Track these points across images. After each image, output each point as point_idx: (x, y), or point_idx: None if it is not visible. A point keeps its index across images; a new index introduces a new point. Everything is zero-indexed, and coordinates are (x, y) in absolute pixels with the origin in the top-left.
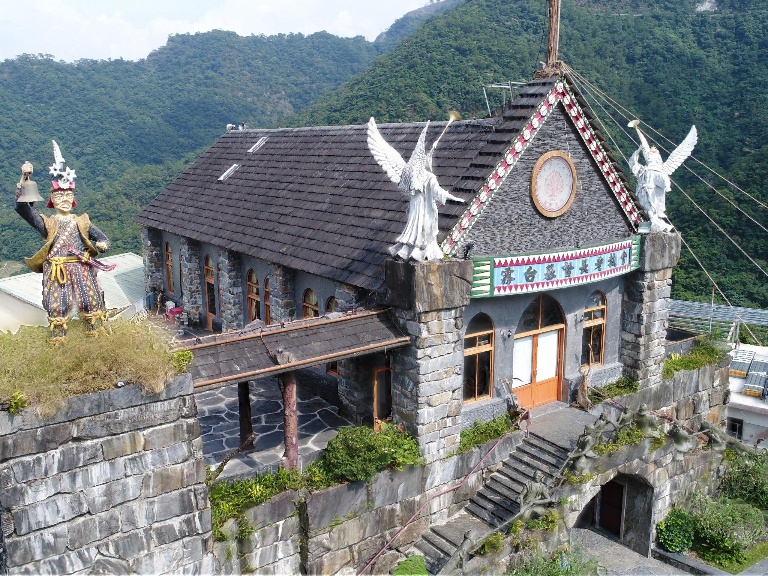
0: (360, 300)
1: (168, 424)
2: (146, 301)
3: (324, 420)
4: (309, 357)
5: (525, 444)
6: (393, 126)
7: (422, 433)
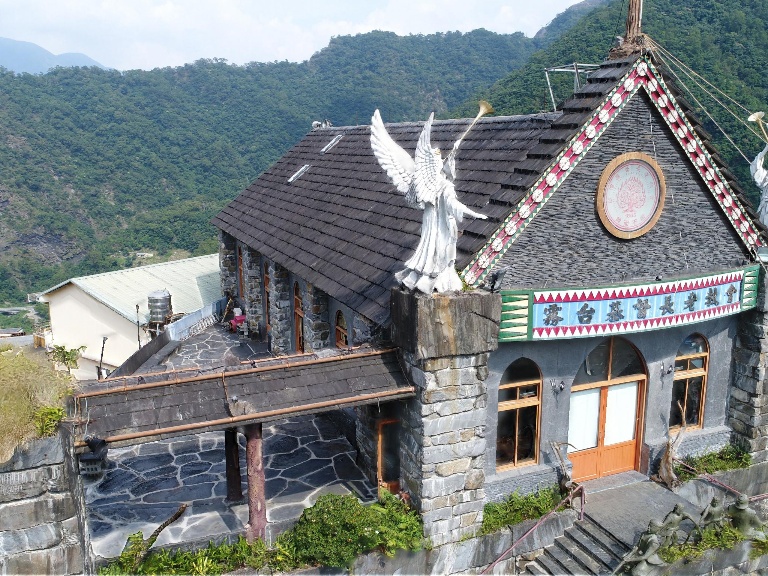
0: (376, 332)
1: (28, 499)
2: (216, 306)
3: (337, 469)
4: (275, 407)
5: (576, 528)
6: (457, 122)
7: (428, 508)
